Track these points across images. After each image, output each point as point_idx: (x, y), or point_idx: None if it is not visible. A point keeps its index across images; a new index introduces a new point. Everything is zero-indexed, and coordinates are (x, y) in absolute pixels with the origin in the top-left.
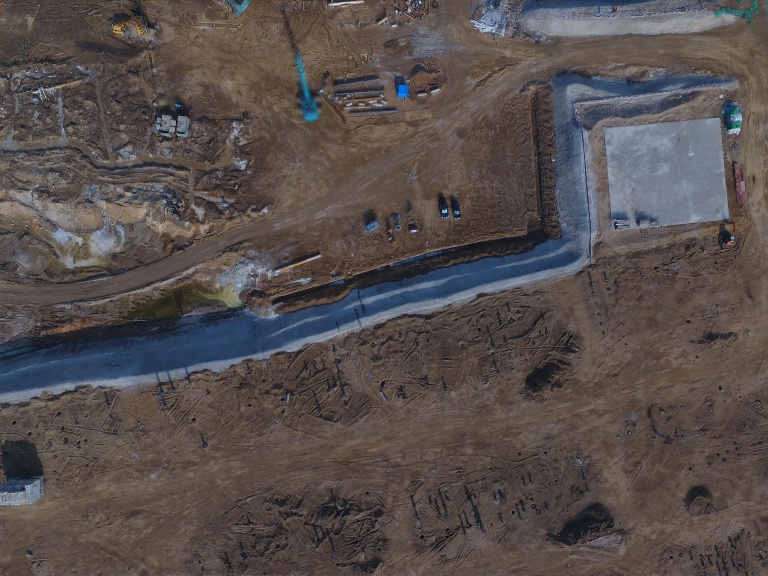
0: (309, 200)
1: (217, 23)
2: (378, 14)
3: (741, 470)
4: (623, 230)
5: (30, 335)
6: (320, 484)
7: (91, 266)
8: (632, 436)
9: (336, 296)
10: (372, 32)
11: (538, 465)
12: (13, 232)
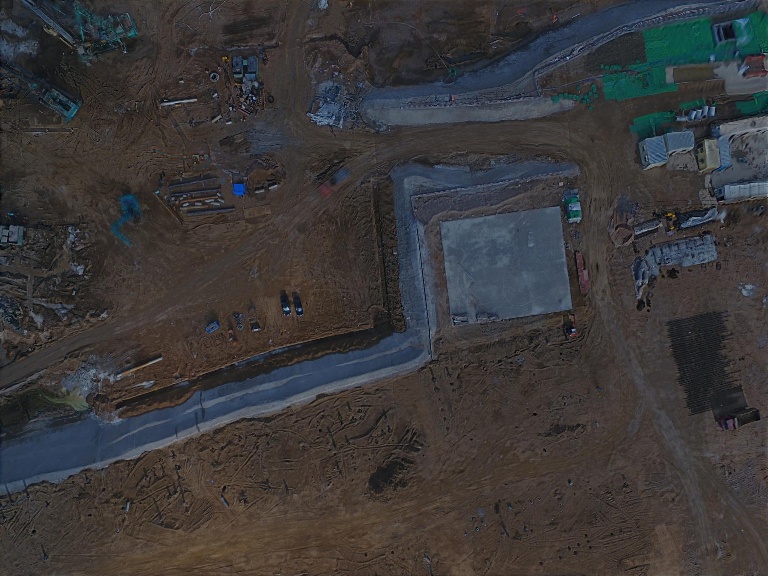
0: (149, 303)
1: (50, 128)
2: (213, 111)
3: (593, 563)
4: (463, 325)
5: None
6: None
7: None
8: (480, 533)
9: (178, 399)
10: (207, 130)
11: (385, 565)
12: None
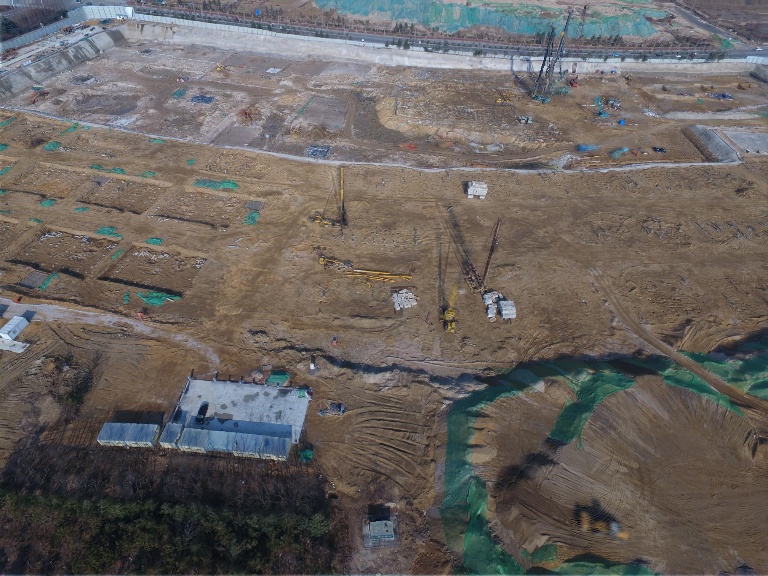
0: None
1: (536, 105)
2: None
3: None
4: (752, 154)
5: None
6: (639, 212)
7: None
8: None
9: (616, 165)
10: None
11: (765, 220)
12: None
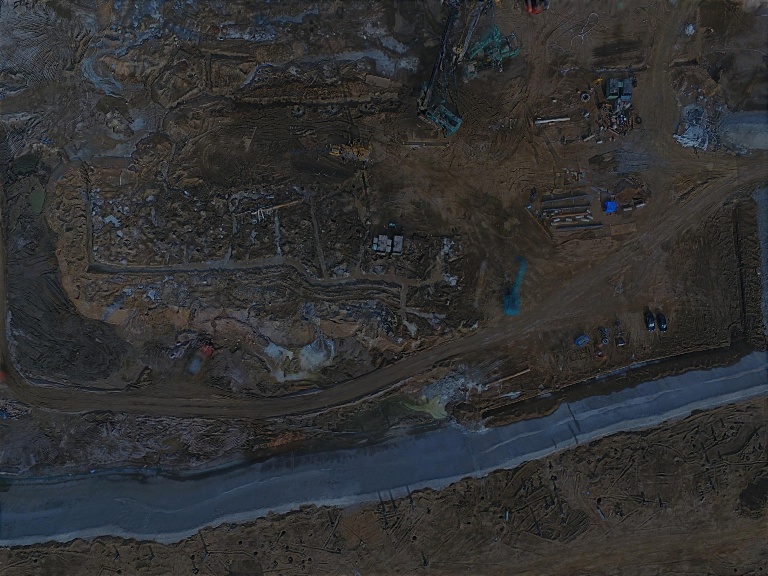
0: (518, 315)
1: (427, 142)
2: (583, 130)
3: None
4: None
5: (243, 449)
6: None
7: (301, 379)
8: None
9: (547, 411)
10: (577, 148)
11: None
12: (226, 347)
